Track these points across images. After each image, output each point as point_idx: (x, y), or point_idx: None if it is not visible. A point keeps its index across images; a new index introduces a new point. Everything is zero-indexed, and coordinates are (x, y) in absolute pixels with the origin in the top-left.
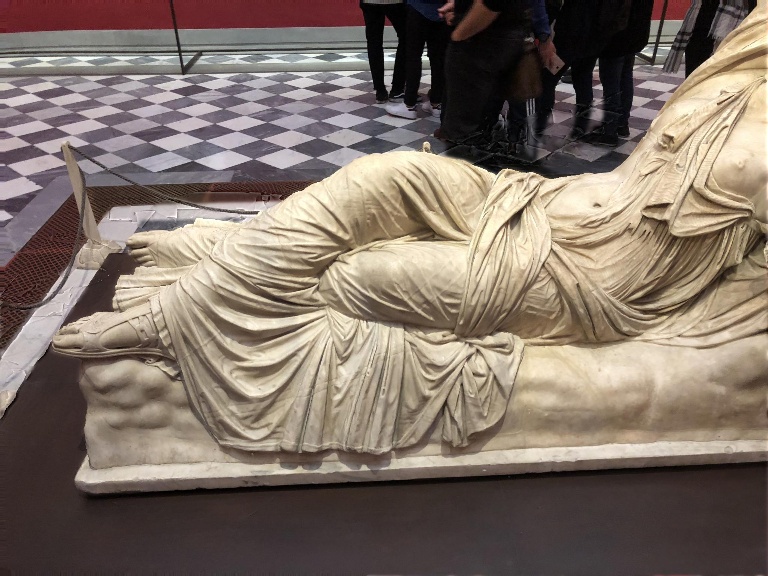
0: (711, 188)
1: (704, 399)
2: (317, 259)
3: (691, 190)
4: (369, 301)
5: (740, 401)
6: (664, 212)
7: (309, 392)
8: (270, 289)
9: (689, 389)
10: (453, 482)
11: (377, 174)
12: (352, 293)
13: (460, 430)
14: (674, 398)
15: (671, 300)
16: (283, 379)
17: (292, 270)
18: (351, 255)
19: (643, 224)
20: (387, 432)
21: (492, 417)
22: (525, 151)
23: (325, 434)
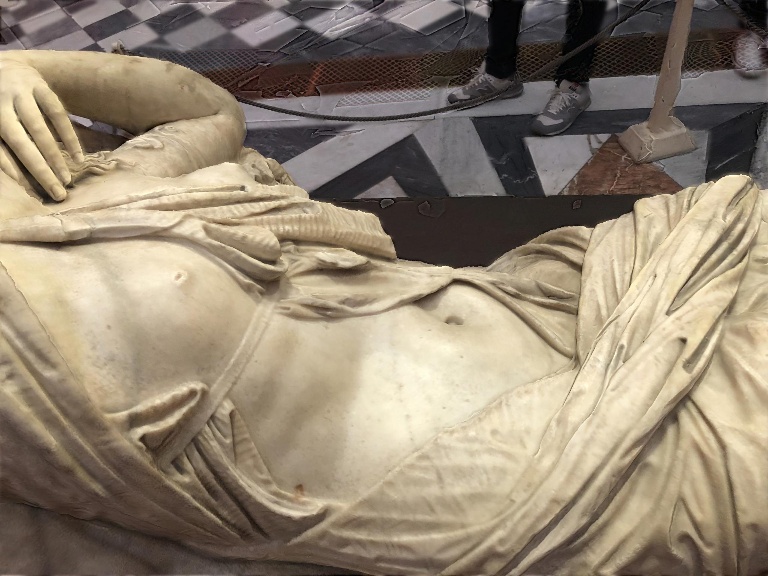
0: None
1: None
2: None
3: None
4: None
5: None
6: None
7: None
8: None
9: None
10: None
11: None
12: None
13: None
14: None
15: None
16: None
17: None
18: None
19: None
20: None
21: None
22: None
23: None
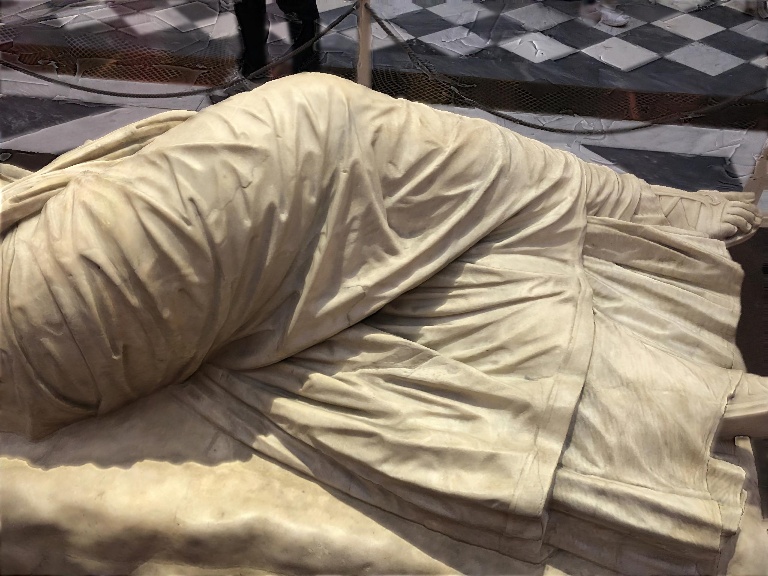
0: None
1: None
2: None
3: None
4: None
5: None
6: None
7: None
8: None
9: None
10: None
11: None
12: None
13: None
14: None
15: None
16: None
17: None
18: None
19: None
20: None
21: None
22: None
23: None
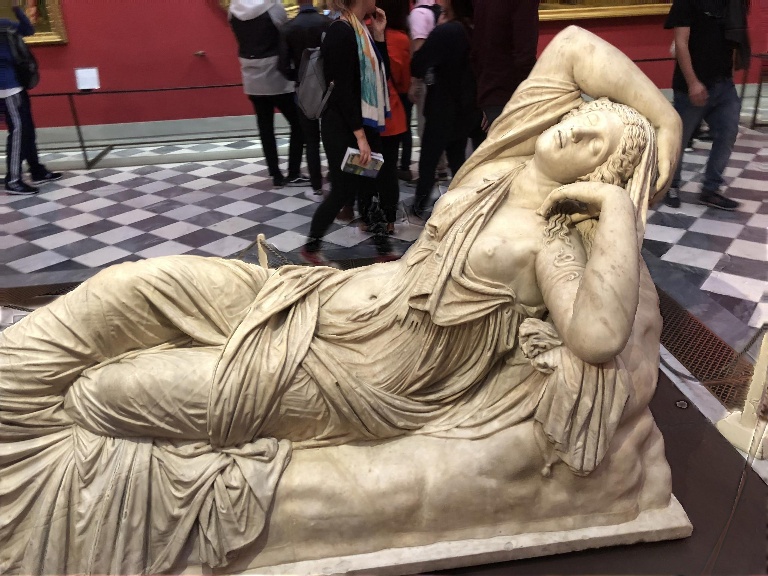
0: (469, 276)
1: (475, 494)
2: (55, 377)
3: (450, 279)
4: (109, 418)
5: (512, 493)
6: (425, 303)
7: (47, 521)
8: (1, 412)
9: (459, 485)
10: None
11: (118, 284)
12: (93, 410)
13: (215, 549)
14: (444, 496)
15: (451, 389)
16: (19, 509)
17: (26, 390)
18: (97, 369)
19: (411, 315)
20: (134, 558)
21: (252, 532)
22: (405, 230)
23: (70, 565)
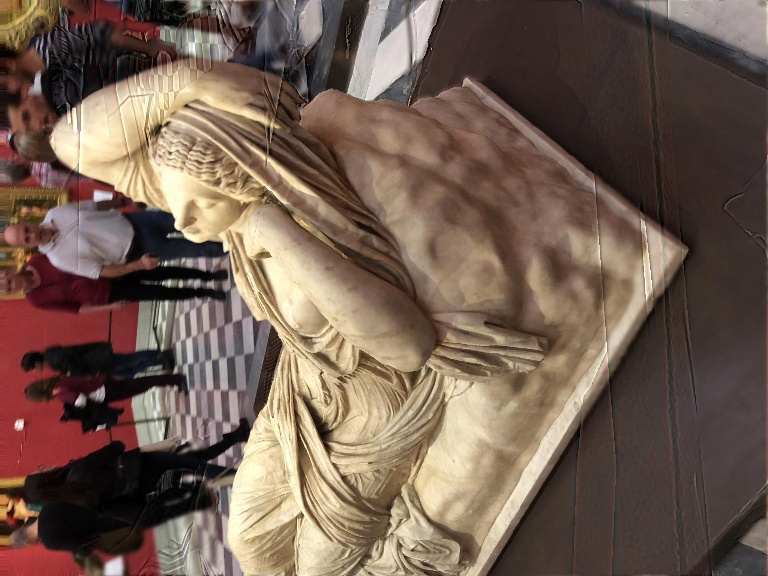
0: None
1: (514, 420)
2: None
3: None
4: None
5: (531, 394)
6: None
7: None
8: None
9: (498, 426)
10: (497, 564)
11: (240, 549)
12: None
13: None
14: (501, 437)
15: None
16: None
17: None
18: (298, 567)
19: None
20: None
21: (454, 545)
22: (308, 29)
23: None
